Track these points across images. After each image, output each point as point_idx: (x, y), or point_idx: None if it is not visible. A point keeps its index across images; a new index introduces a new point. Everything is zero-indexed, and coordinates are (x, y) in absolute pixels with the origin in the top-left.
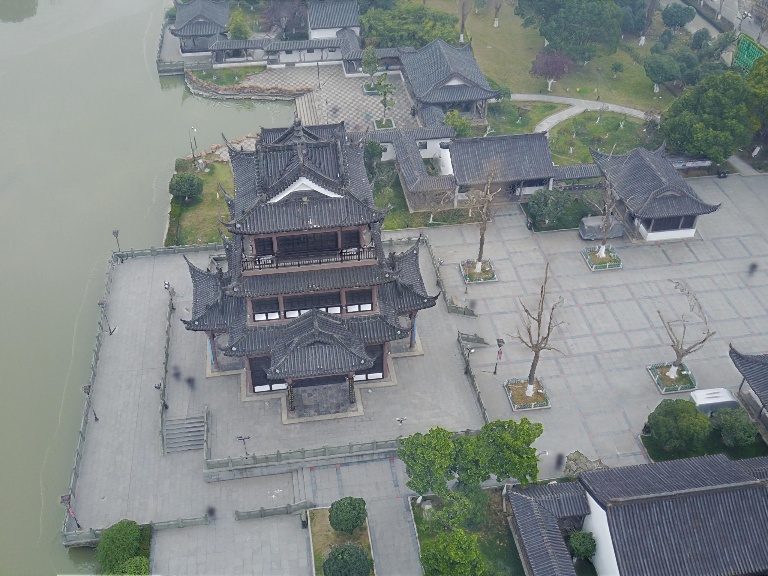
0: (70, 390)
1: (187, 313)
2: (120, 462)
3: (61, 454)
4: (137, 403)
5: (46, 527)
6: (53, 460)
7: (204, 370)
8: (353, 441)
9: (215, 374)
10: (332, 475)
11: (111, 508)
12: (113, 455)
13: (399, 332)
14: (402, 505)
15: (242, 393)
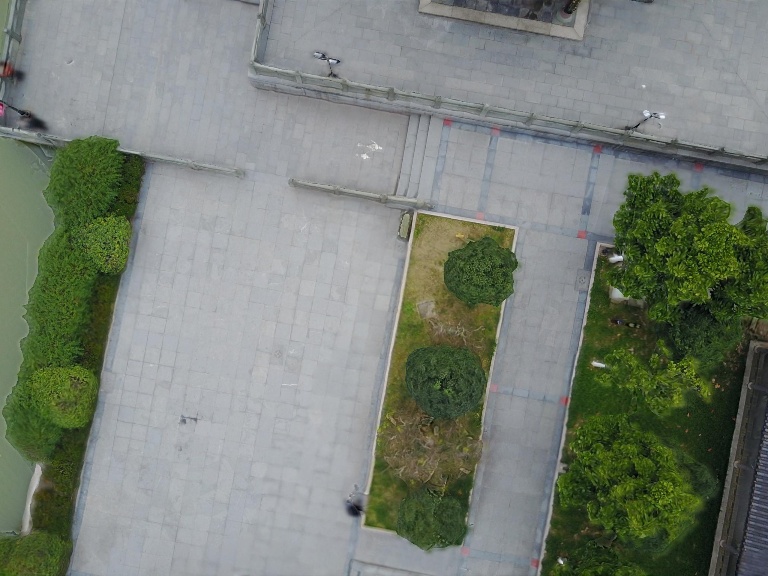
0: None
1: None
2: None
3: None
4: None
5: None
6: None
7: None
8: (540, 97)
9: None
10: (479, 150)
11: (81, 87)
12: None
13: None
14: (581, 255)
15: None
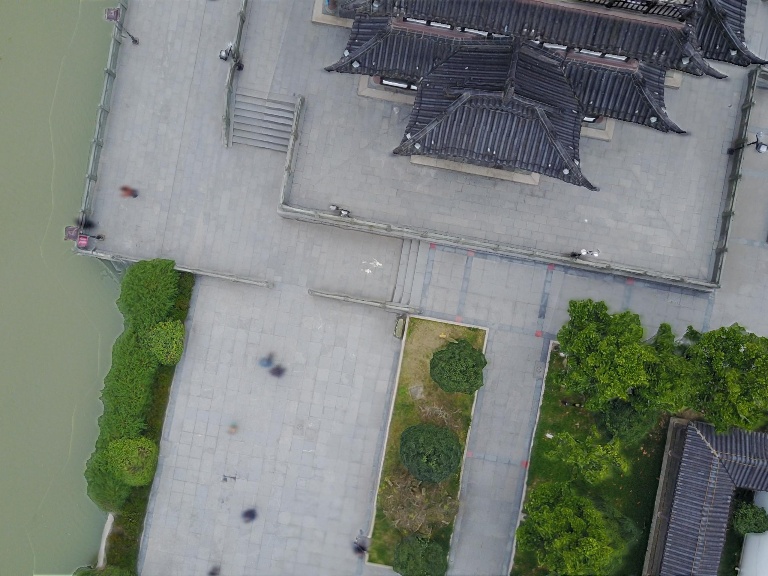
0: None
1: None
2: (163, 137)
3: (83, 76)
4: (199, 25)
5: (62, 196)
6: (70, 91)
7: (311, 2)
8: (505, 229)
9: (327, 19)
10: (458, 267)
11: (145, 216)
12: (154, 121)
13: (654, 119)
14: (538, 350)
15: (362, 76)
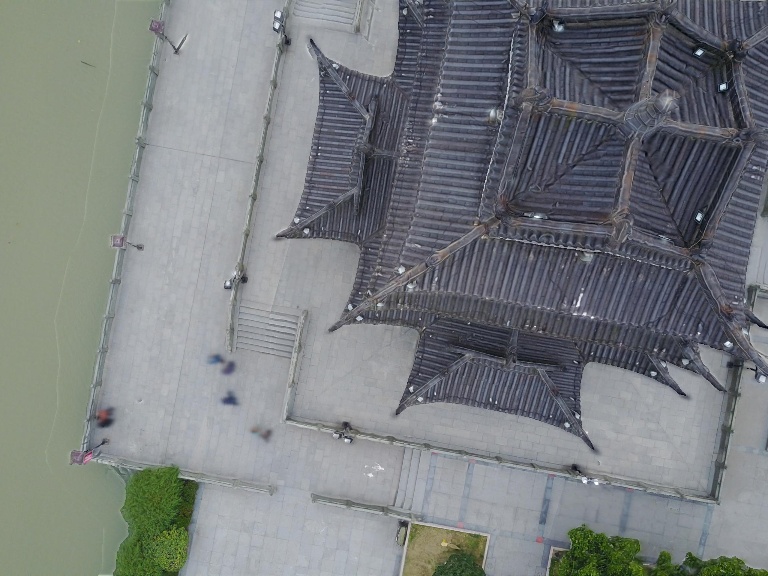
0: (105, 152)
1: (309, 60)
2: (168, 343)
3: (89, 275)
4: (203, 231)
5: (67, 392)
6: (75, 293)
7: None
8: (507, 441)
9: None
10: (459, 474)
11: (149, 421)
12: (159, 326)
13: (654, 374)
14: (539, 555)
15: None
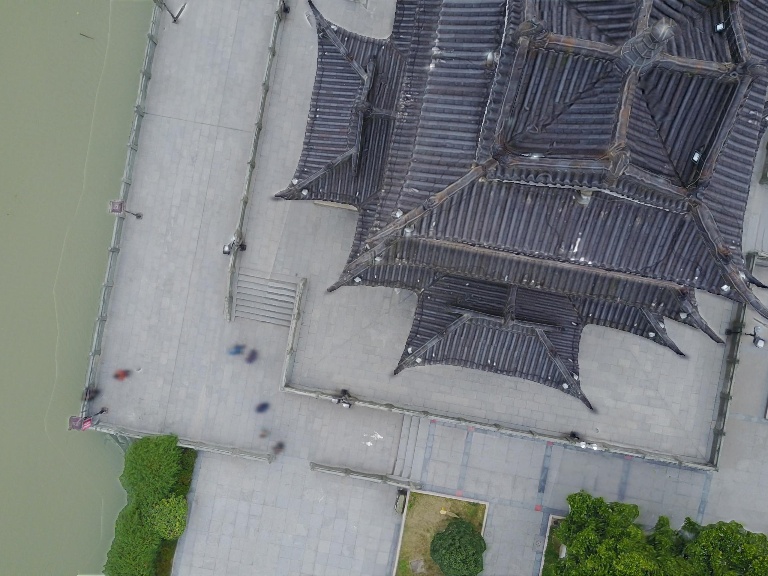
0: (104, 122)
1: (308, 28)
2: (166, 311)
3: (87, 245)
4: (202, 200)
5: (65, 362)
6: (74, 262)
7: None
8: (505, 408)
9: None
10: (458, 442)
11: (148, 389)
12: (158, 295)
13: (652, 335)
14: (537, 524)
15: None
